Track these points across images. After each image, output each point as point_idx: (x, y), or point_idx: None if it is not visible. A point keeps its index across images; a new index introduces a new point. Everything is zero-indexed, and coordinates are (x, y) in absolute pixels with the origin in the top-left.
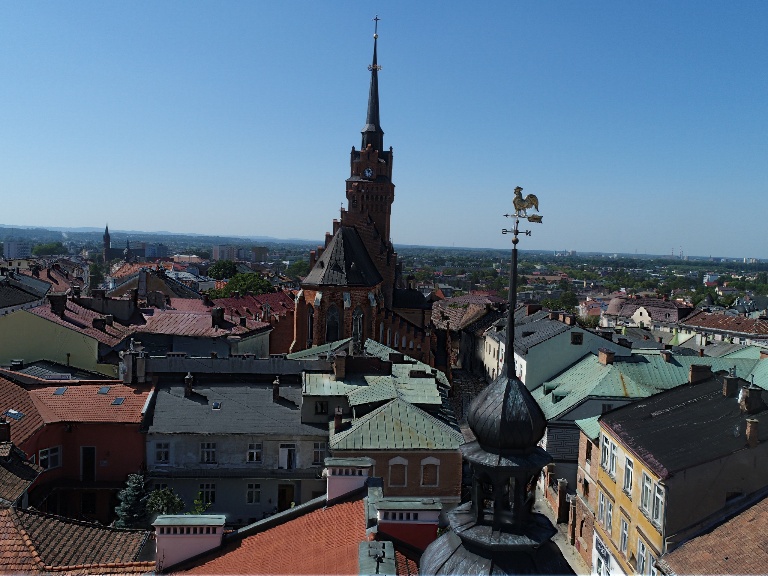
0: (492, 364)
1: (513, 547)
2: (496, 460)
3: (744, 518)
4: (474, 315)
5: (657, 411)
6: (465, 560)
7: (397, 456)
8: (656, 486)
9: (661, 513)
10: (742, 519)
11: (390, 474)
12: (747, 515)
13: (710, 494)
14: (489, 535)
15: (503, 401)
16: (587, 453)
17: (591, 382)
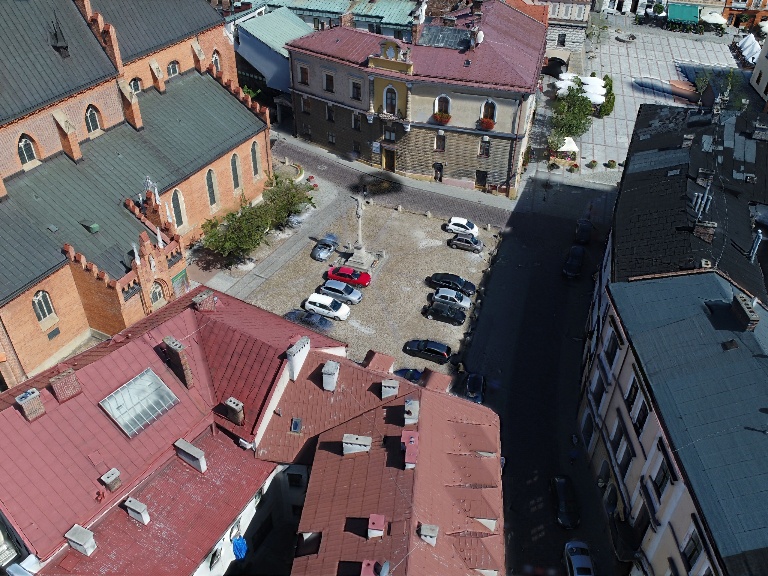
0: None
1: None
2: None
3: None
4: None
5: None
6: None
7: None
8: None
9: None
10: None
11: None
12: None
13: None
14: None
15: None
16: None
17: None
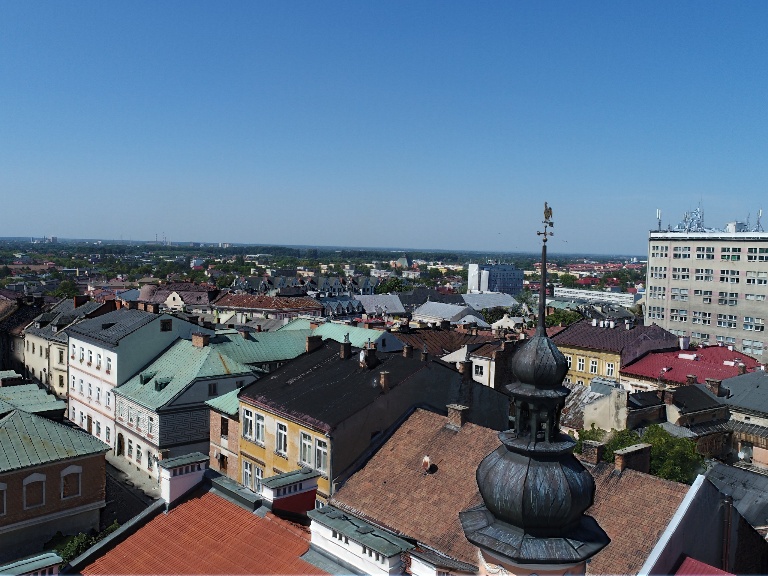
0: (39, 364)
1: (568, 449)
2: (555, 393)
3: (386, 449)
4: (2, 312)
5: (291, 379)
6: (540, 468)
7: (33, 473)
8: (317, 440)
9: (324, 462)
10: (385, 451)
11: (25, 495)
12: (388, 447)
13: (361, 437)
14: (552, 446)
15: (552, 352)
16: (222, 429)
17: (193, 365)
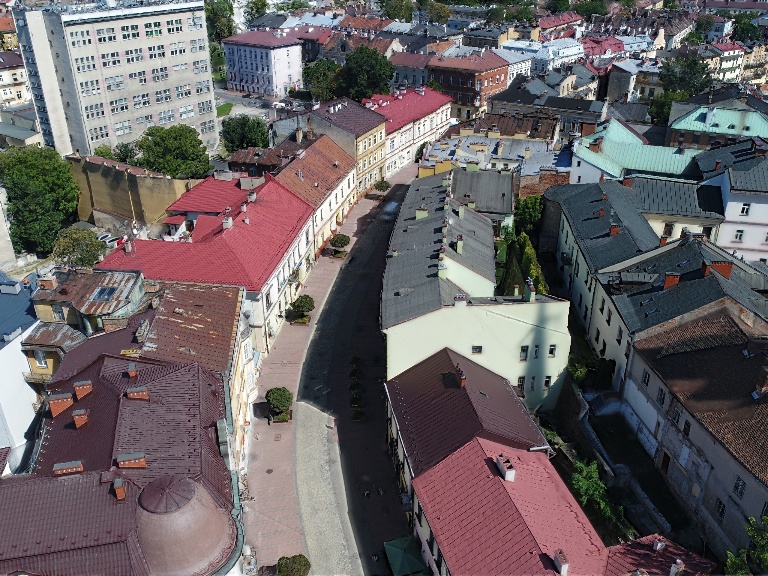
0: None
1: None
2: None
3: None
4: None
5: (762, 111)
6: None
7: None
8: None
9: None
10: None
11: None
12: None
13: None
14: None
15: None
16: None
17: None
